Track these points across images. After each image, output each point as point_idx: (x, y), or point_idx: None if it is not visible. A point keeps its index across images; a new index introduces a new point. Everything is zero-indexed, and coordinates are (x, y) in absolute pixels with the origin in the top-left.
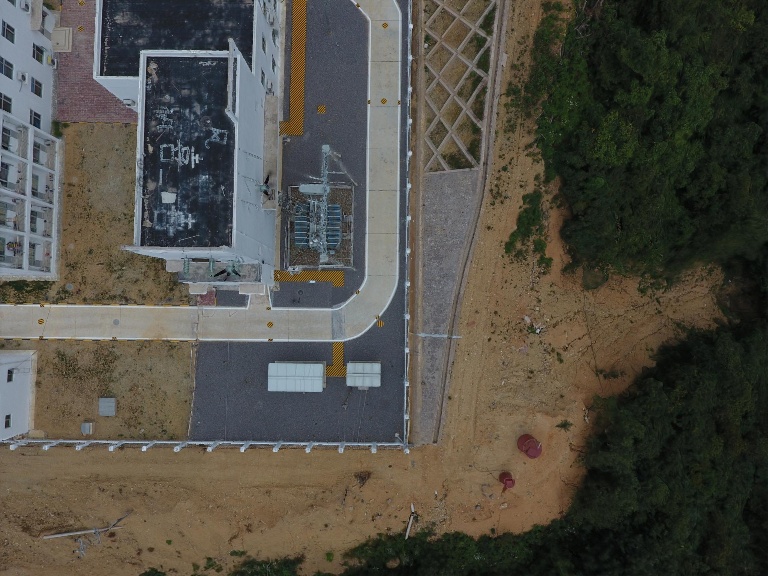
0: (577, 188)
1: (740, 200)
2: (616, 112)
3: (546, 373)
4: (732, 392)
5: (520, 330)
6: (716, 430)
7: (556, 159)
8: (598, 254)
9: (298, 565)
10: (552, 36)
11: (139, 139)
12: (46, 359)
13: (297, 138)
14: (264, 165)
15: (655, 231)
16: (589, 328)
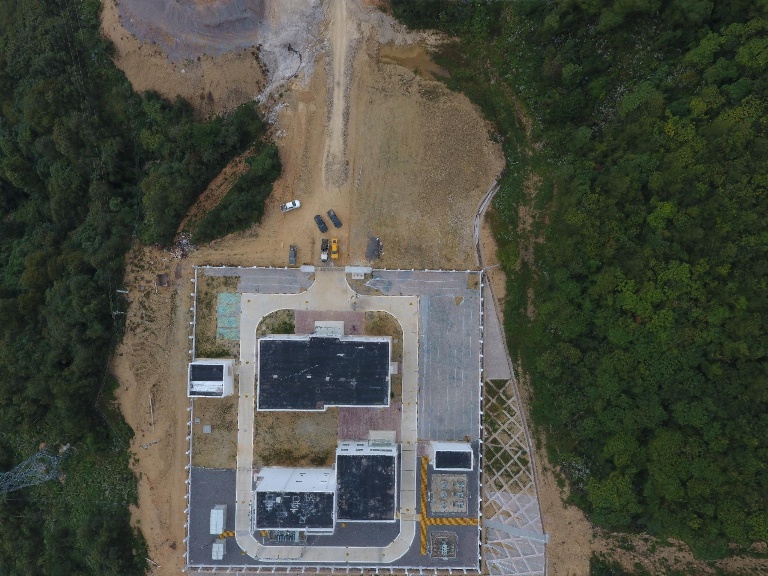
0: None
1: None
2: None
3: None
4: None
5: None
6: None
7: None
8: None
9: (135, 505)
10: None
11: None
12: (229, 399)
13: None
14: None
15: None
16: None
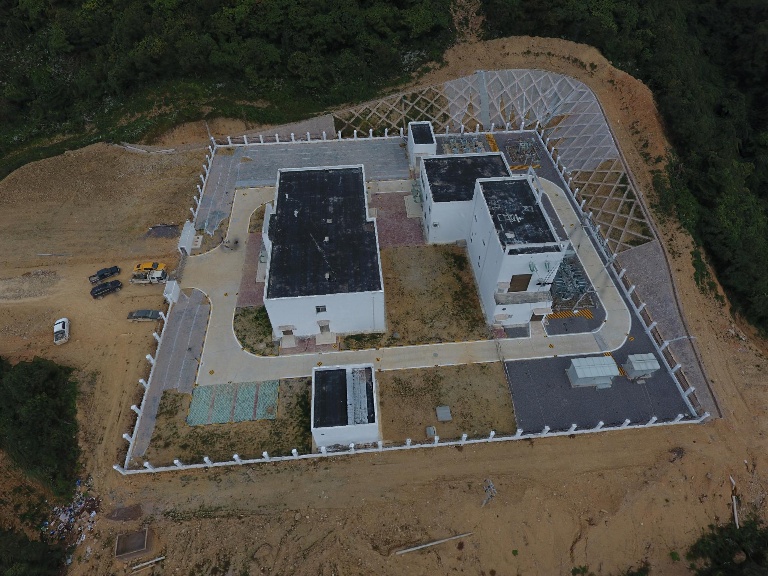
0: (721, 245)
1: None
2: (723, 204)
3: None
4: None
5: (731, 337)
6: None
7: (697, 236)
8: (753, 288)
9: (645, 575)
10: None
11: None
12: (386, 385)
13: None
14: None
15: None
16: None
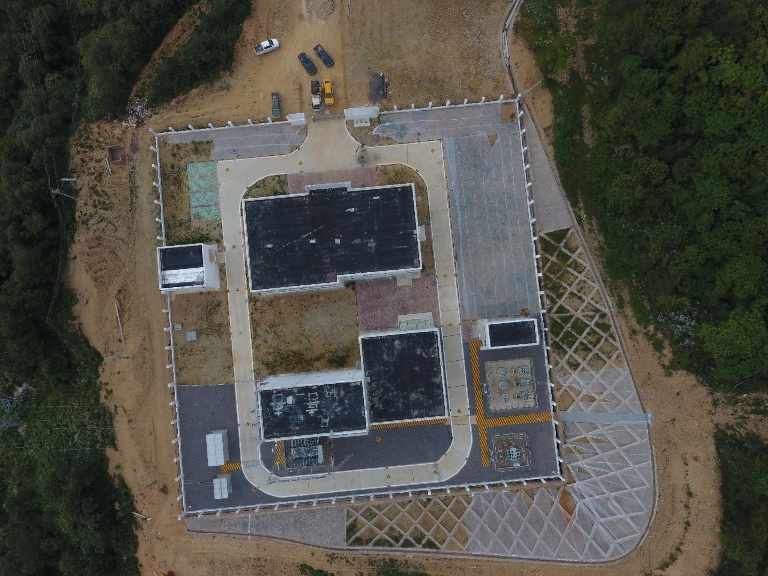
0: None
1: None
2: None
3: None
4: None
5: (260, 573)
6: None
7: None
8: None
9: (112, 447)
10: None
11: None
12: (216, 296)
13: None
14: None
15: None
16: None
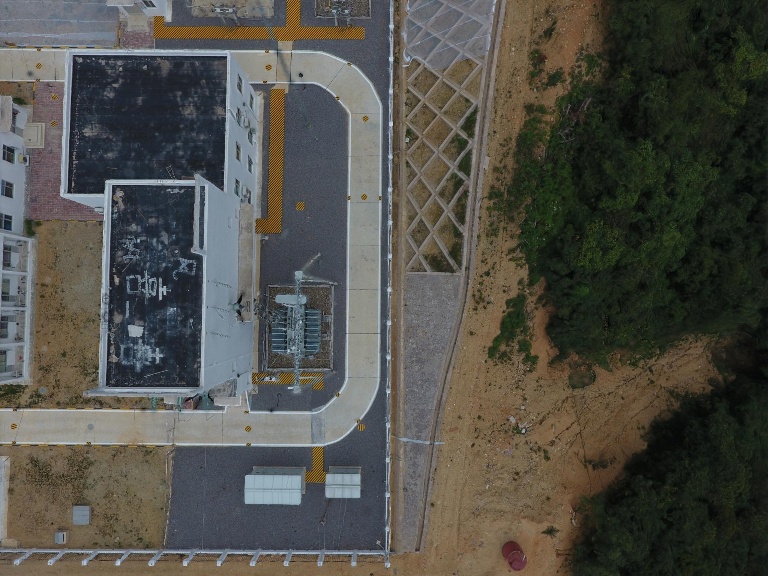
0: (562, 294)
1: (732, 285)
2: (601, 221)
3: (532, 474)
4: (725, 475)
5: (505, 431)
6: (709, 514)
7: (540, 262)
8: (585, 353)
9: None
10: (535, 139)
11: (104, 273)
12: (19, 465)
13: (275, 236)
14: (239, 276)
15: (645, 318)
16: (578, 413)
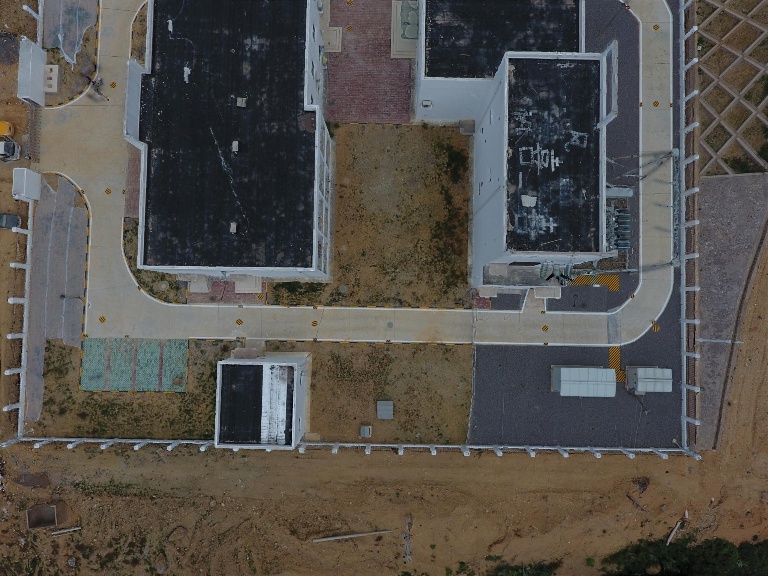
0: None
1: None
2: None
3: None
4: None
5: None
6: None
7: None
8: None
9: (555, 570)
10: None
11: (507, 142)
12: (320, 361)
13: None
14: None
15: None
16: None
